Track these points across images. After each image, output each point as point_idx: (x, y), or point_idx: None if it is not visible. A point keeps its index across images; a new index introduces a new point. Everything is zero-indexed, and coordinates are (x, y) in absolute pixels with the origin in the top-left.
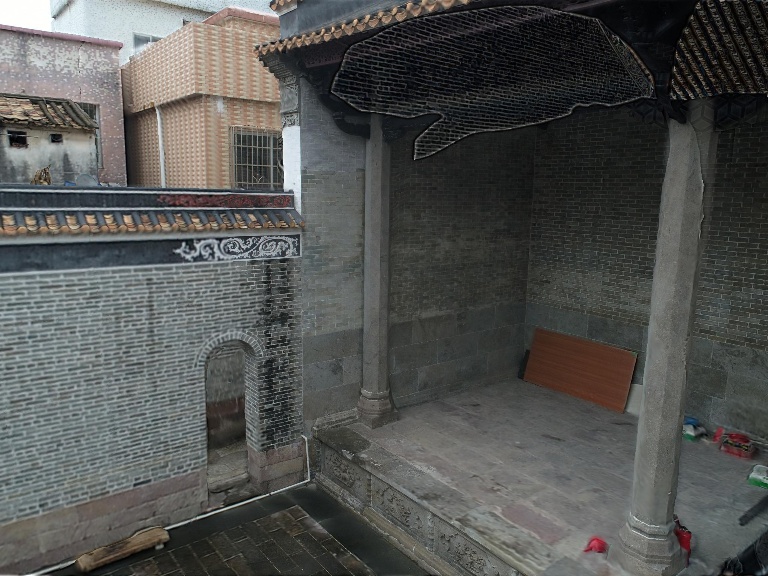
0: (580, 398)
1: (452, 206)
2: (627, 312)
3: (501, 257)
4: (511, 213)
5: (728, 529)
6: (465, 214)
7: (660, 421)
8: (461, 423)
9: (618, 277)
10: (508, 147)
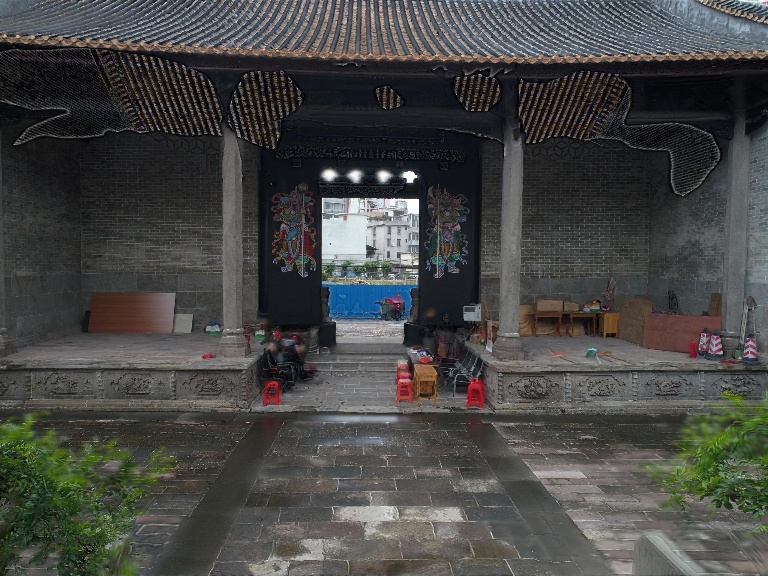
0: (139, 332)
1: (32, 188)
2: (165, 268)
3: (64, 235)
4: (68, 202)
5: (258, 346)
6: (41, 197)
7: (235, 274)
8: (70, 347)
9: (157, 245)
10: (64, 151)
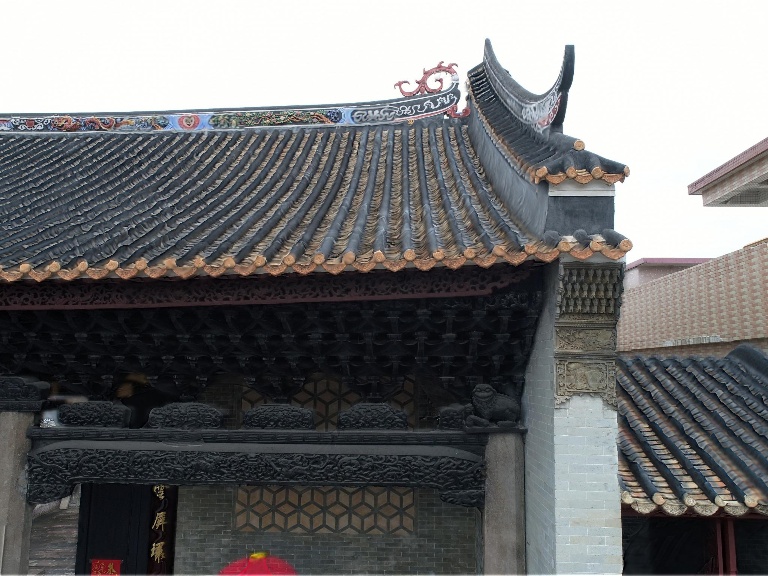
0: None
1: None
2: None
3: None
4: None
5: None
6: None
7: None
8: None
9: None
10: None
